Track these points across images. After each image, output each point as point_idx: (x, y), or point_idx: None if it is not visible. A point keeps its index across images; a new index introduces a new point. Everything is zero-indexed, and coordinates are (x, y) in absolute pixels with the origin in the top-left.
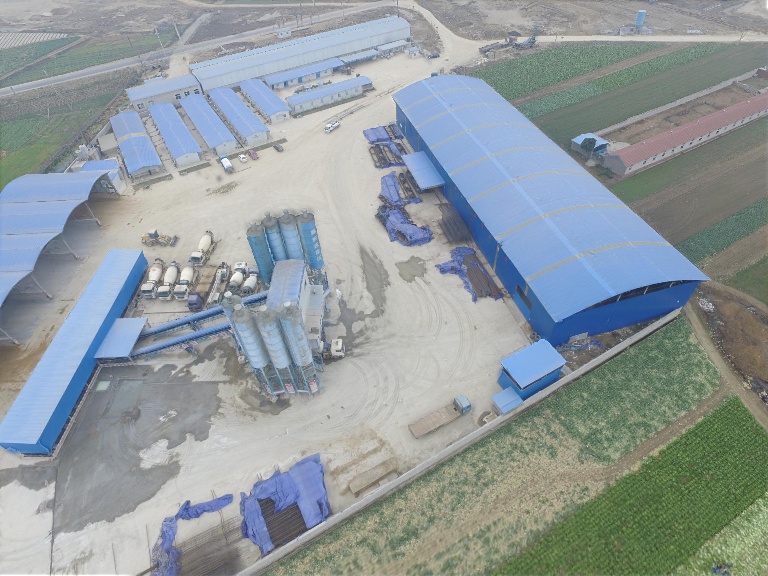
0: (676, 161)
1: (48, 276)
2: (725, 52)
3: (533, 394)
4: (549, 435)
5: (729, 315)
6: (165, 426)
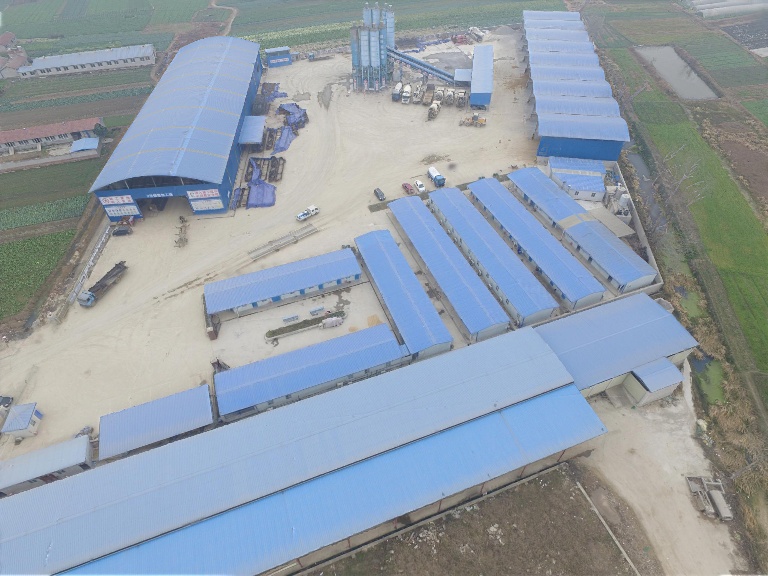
0: None
1: None
2: None
3: None
4: None
5: None
6: None
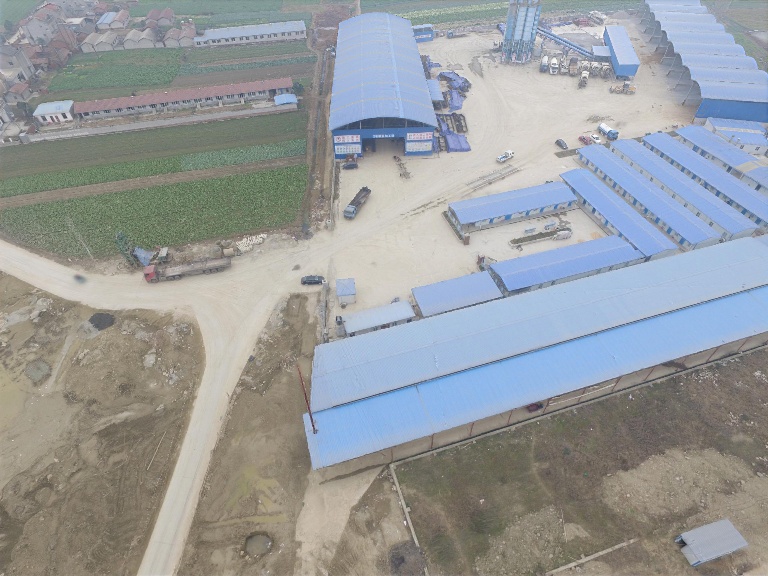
0: None
1: None
2: None
3: None
4: None
5: None
6: None
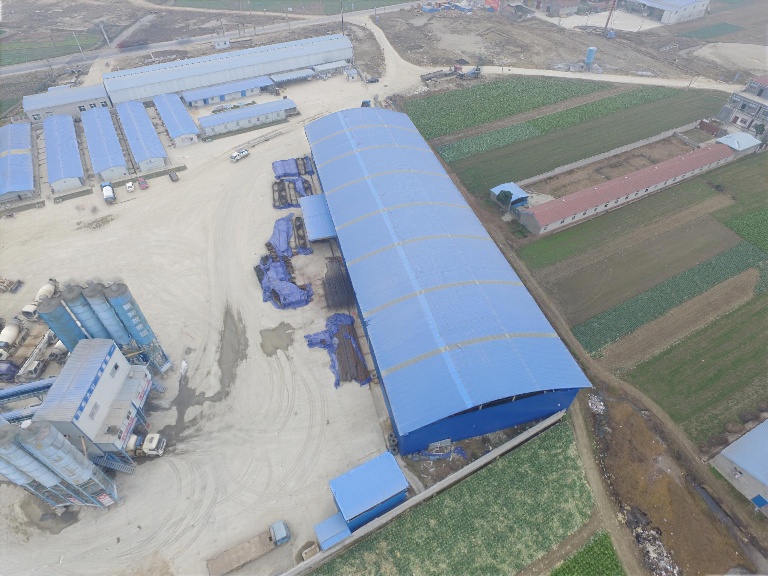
0: (598, 221)
1: None
2: (673, 98)
3: (367, 522)
4: None
5: (619, 420)
6: None
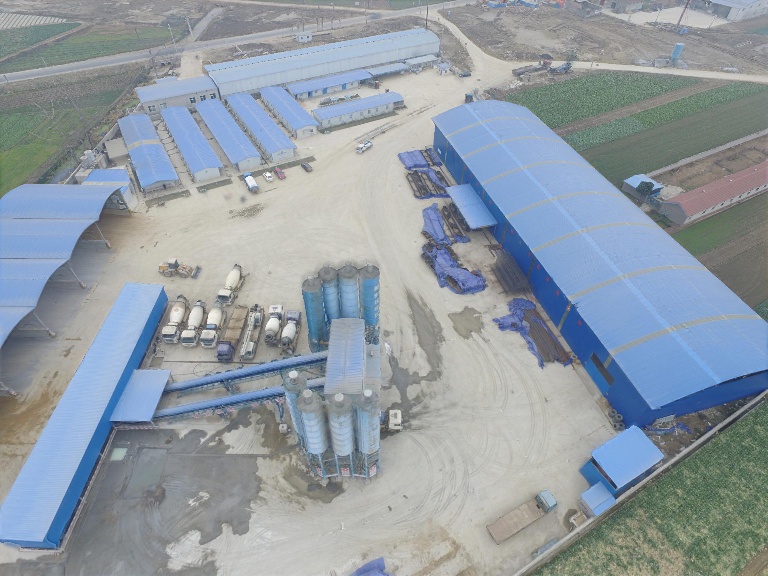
0: (734, 211)
1: (49, 307)
2: (764, 93)
3: (625, 491)
4: (647, 543)
5: None
6: (196, 513)
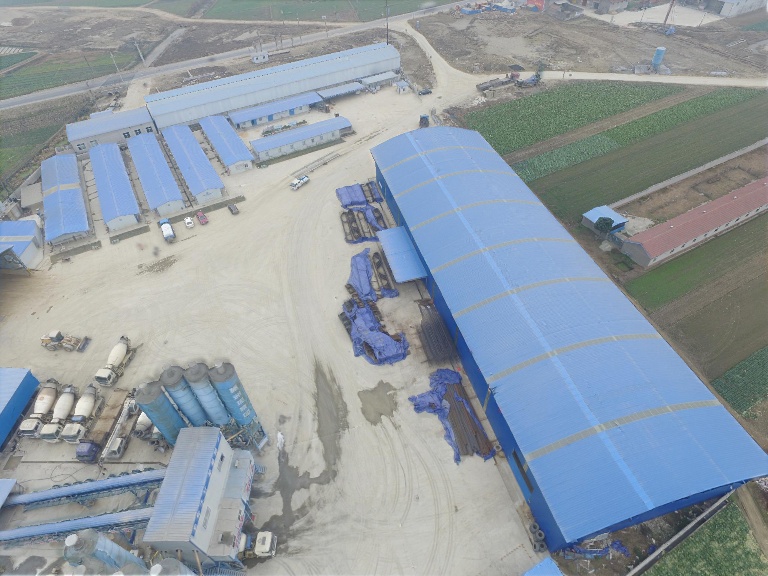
0: (709, 247)
1: None
2: (755, 100)
3: None
4: None
5: None
6: None
